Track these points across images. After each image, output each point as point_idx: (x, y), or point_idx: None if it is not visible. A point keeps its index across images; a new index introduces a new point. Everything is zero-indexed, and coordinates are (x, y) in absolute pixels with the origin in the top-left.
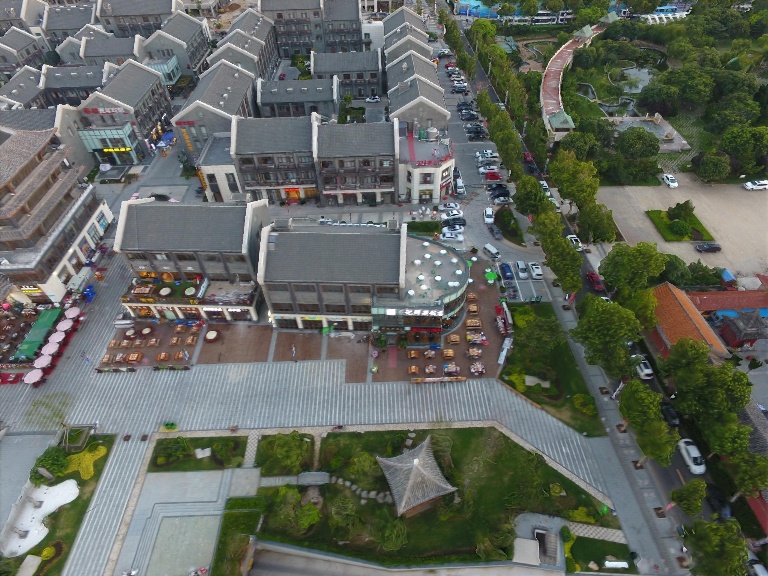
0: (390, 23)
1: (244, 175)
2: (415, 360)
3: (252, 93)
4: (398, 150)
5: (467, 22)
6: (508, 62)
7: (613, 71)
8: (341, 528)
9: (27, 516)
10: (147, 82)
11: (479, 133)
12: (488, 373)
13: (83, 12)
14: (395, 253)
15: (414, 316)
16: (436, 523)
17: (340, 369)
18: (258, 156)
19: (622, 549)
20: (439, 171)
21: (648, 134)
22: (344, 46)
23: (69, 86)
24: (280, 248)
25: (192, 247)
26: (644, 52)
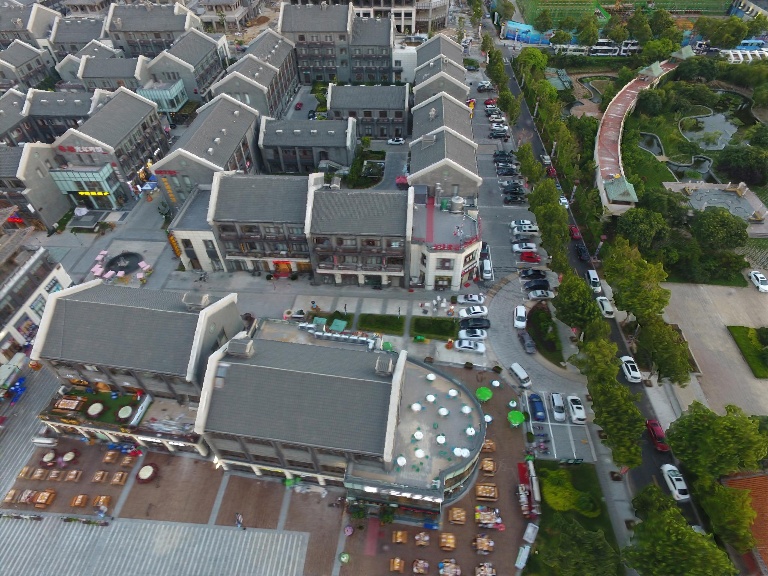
0: (424, 52)
1: (225, 242)
2: (402, 546)
3: (254, 133)
4: (410, 231)
5: (514, 50)
6: (559, 106)
7: (686, 122)
8: None
9: None
10: (138, 114)
11: (517, 194)
12: None
13: (94, 25)
14: (382, 410)
15: (402, 496)
16: None
17: (300, 549)
18: (241, 224)
19: None
20: (461, 257)
21: (735, 220)
22: (372, 73)
23: (54, 114)
24: (230, 385)
25: (126, 363)
26: (723, 96)
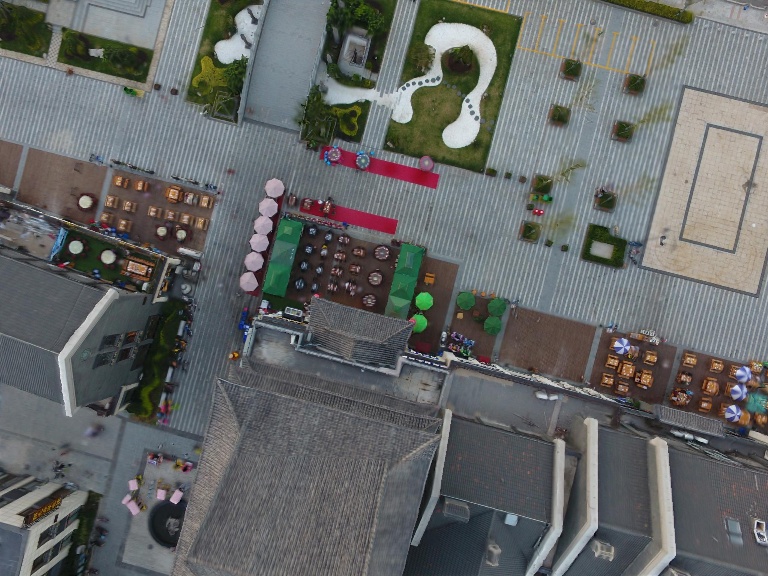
0: None
1: None
2: None
3: None
4: None
5: None
6: None
7: None
8: None
9: None
10: None
11: None
12: None
13: None
14: None
15: None
16: None
17: None
18: None
19: None
20: None
21: None
22: None
23: None
24: None
25: (5, 262)
26: None
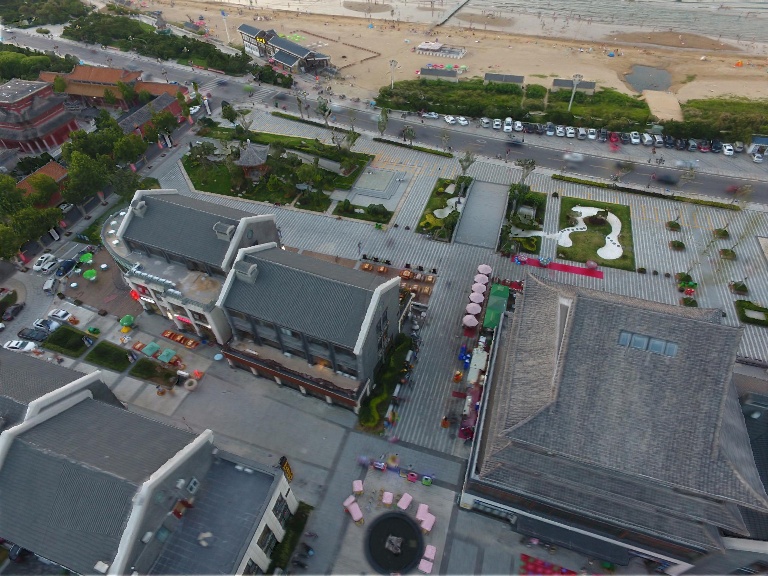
0: None
1: None
2: None
3: None
4: None
5: None
6: None
7: None
8: None
9: None
10: None
11: None
12: None
13: None
14: None
15: None
16: None
17: None
18: None
19: (192, 151)
20: None
21: None
22: None
23: None
24: None
25: (321, 261)
26: None
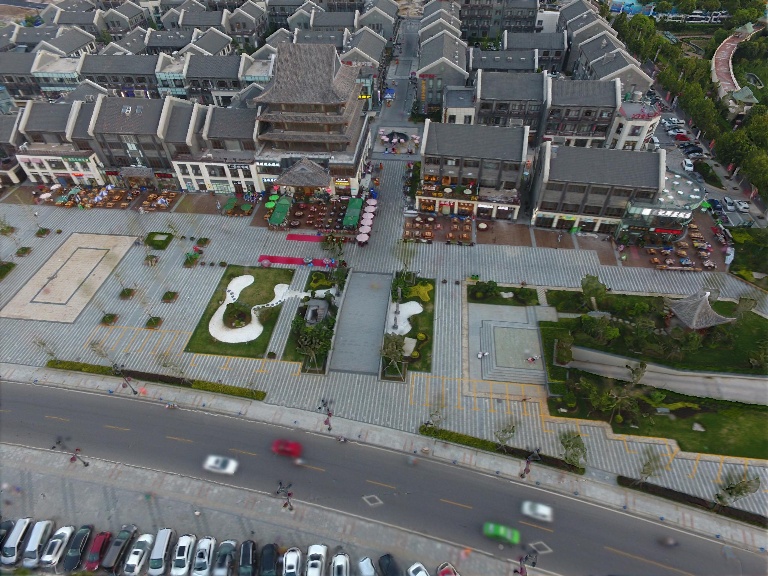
0: (569, 11)
1: (479, 118)
2: (654, 256)
3: None
4: None
5: None
6: None
7: None
8: (641, 339)
9: (392, 318)
10: (379, 46)
11: None
12: (718, 269)
13: None
14: (655, 166)
15: (663, 217)
16: (706, 350)
17: (594, 256)
18: (497, 102)
19: None
20: (649, 124)
21: None
22: (517, 31)
23: None
24: (560, 157)
25: (481, 155)
26: None
